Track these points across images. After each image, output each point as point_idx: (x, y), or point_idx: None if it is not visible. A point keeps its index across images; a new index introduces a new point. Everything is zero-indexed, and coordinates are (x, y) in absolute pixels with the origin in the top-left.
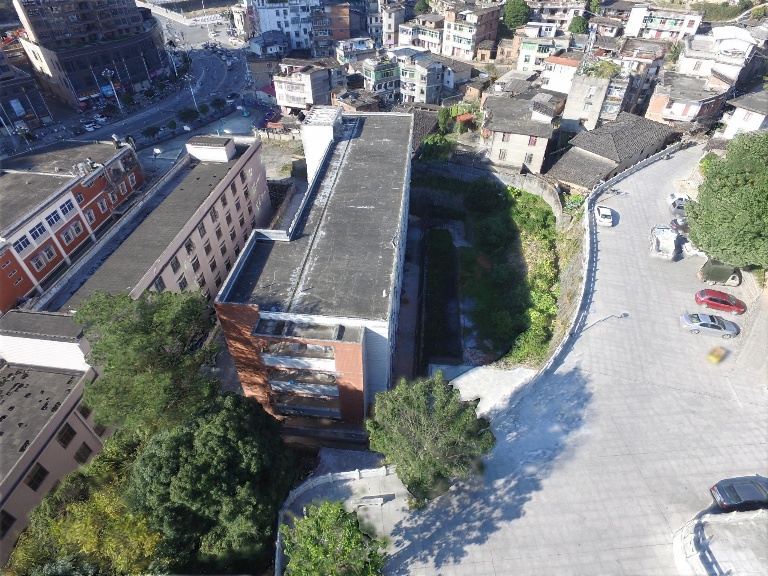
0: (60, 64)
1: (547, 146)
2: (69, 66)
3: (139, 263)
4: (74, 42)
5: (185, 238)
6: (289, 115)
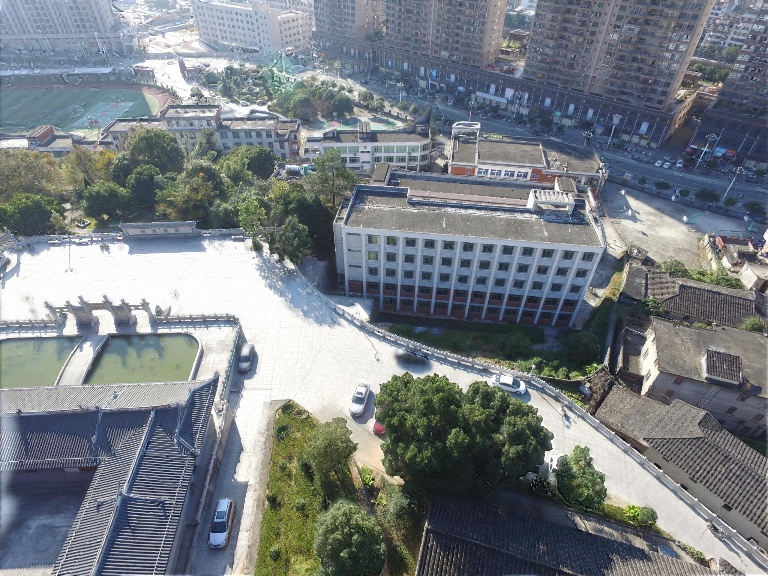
0: (703, 116)
1: (757, 441)
2: (708, 121)
3: (435, 190)
4: (745, 108)
5: (460, 199)
6: (752, 248)
